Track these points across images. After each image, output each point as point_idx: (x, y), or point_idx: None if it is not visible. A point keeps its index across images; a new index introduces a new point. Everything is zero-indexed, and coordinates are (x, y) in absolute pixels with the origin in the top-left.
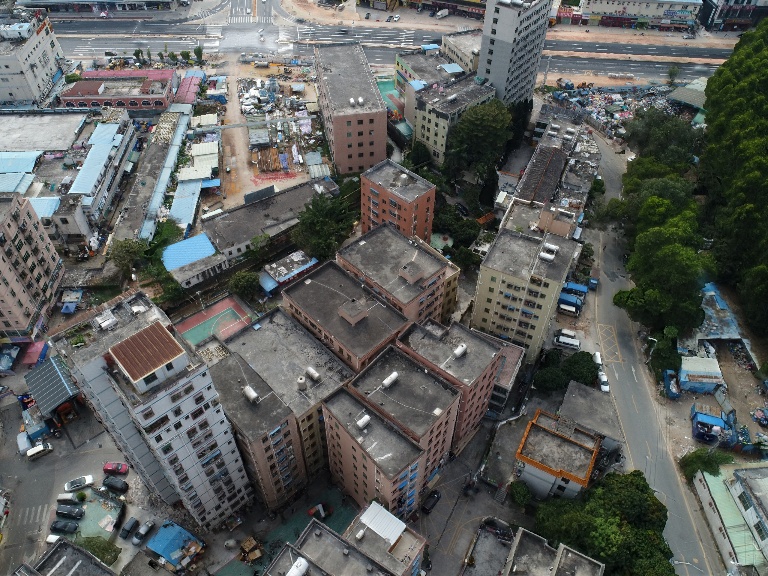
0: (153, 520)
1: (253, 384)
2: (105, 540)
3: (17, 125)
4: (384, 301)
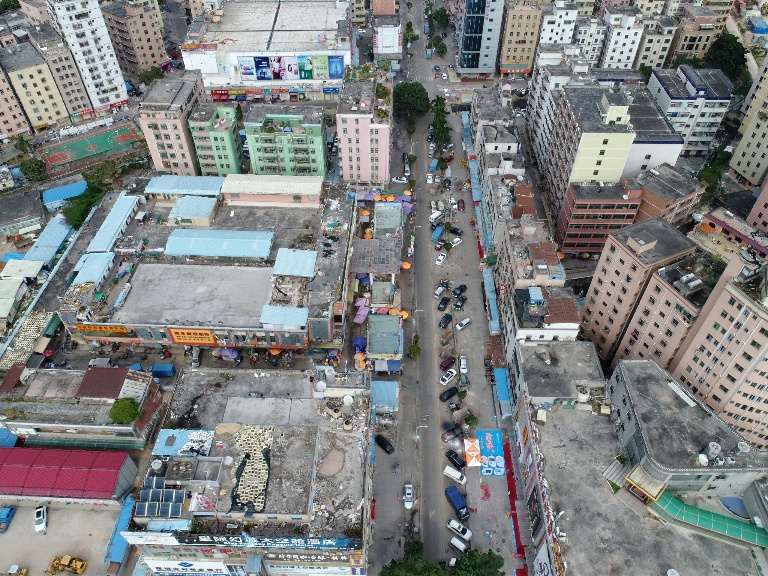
0: (130, 96)
1: (37, 34)
2: (143, 76)
3: (203, 307)
4: None
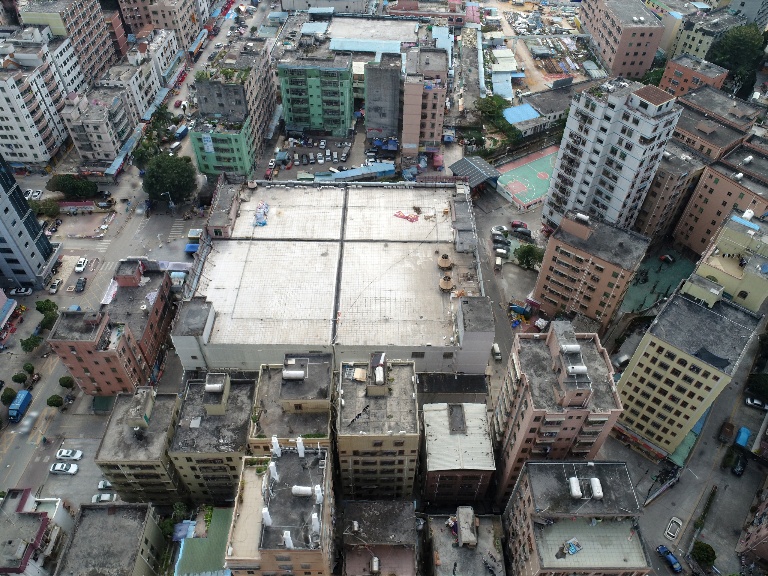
0: None
1: None
2: None
3: (369, 25)
4: (726, 123)
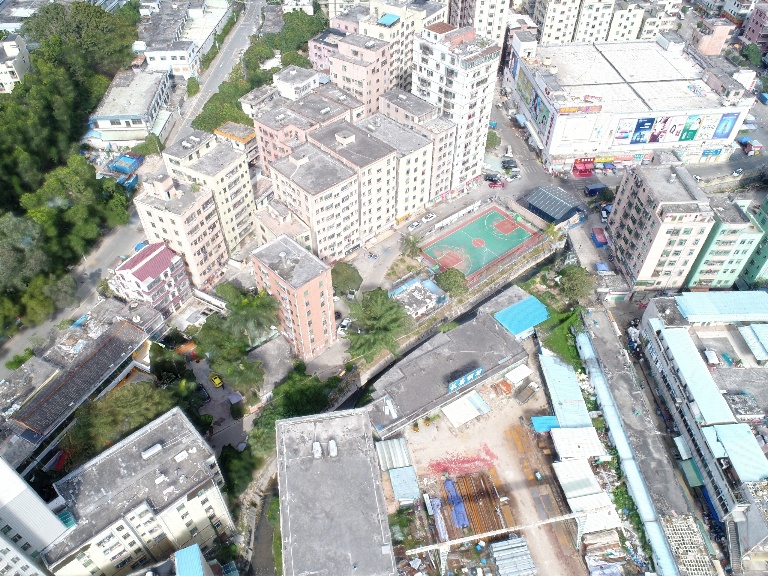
0: None
1: (403, 105)
2: None
3: None
4: None
